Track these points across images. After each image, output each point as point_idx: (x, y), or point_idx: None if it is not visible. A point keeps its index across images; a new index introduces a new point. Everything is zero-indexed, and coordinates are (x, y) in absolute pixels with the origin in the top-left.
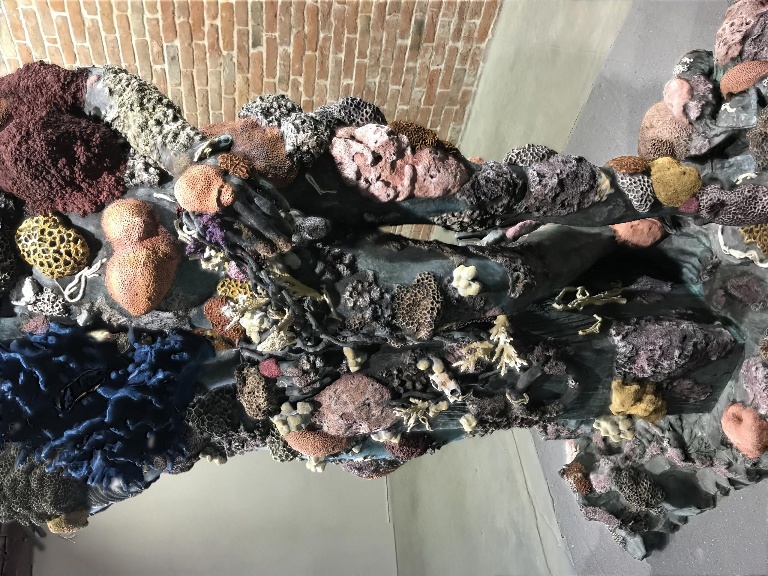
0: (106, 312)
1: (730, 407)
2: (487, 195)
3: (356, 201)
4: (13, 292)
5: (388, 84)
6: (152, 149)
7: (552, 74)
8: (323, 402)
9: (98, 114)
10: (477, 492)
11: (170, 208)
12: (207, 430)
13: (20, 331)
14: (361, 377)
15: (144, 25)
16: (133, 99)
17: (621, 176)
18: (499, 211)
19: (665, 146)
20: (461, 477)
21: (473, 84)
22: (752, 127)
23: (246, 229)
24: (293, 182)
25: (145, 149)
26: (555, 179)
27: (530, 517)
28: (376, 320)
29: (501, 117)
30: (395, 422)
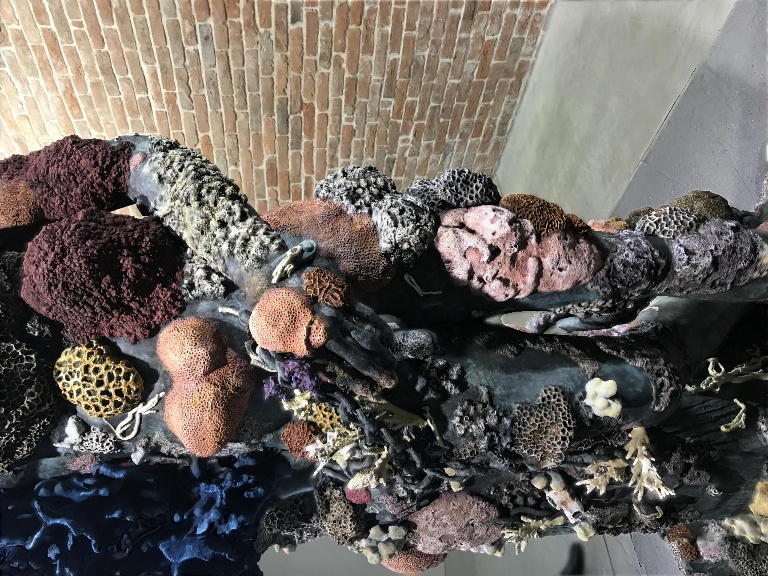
0: (165, 446)
1: None
2: (624, 282)
3: (464, 300)
4: (55, 433)
5: (438, 57)
6: (216, 258)
7: (631, 50)
8: (419, 523)
9: (145, 203)
10: None
11: (239, 325)
12: (277, 528)
13: (65, 469)
14: (465, 496)
15: (175, 4)
16: (189, 190)
17: None
18: (635, 296)
19: None
20: None
21: (531, 54)
22: None
23: (341, 371)
24: (389, 284)
25: (207, 257)
26: (709, 258)
27: None
28: (492, 449)
29: (565, 93)
30: (500, 537)
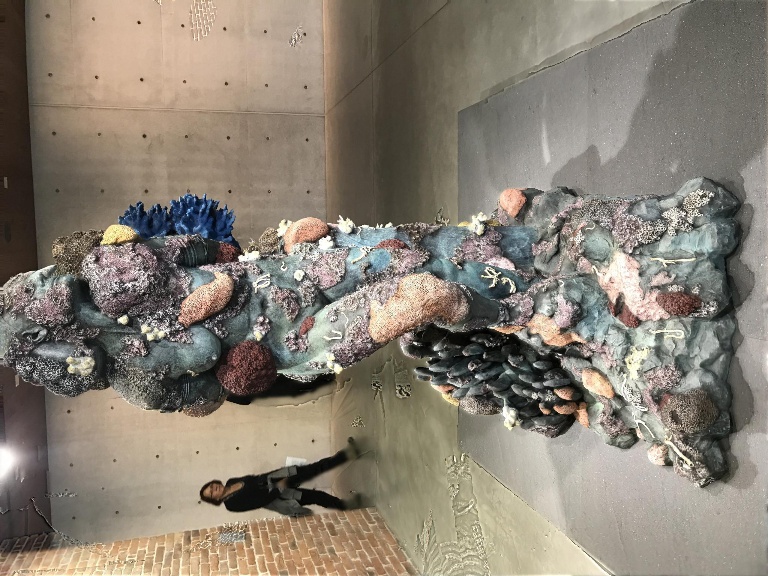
0: None
1: None
2: None
3: None
4: None
5: None
6: None
7: None
8: None
9: None
10: None
11: None
12: None
13: None
14: None
15: None
16: None
17: None
18: None
19: None
20: None
21: None
22: None
23: None
24: None
25: None
26: None
27: None
28: None
29: None
30: None
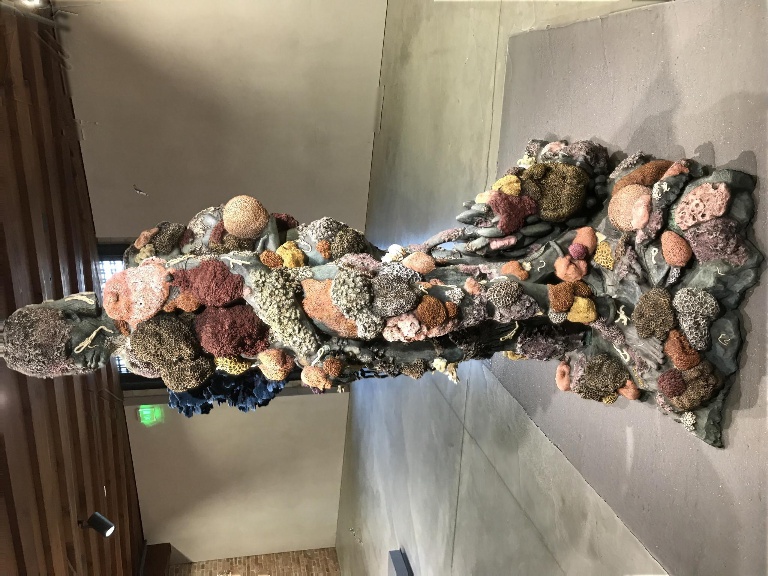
0: None
1: (564, 366)
2: (466, 327)
3: None
4: None
5: None
6: None
7: None
8: None
9: None
10: (454, 116)
11: None
12: None
13: None
14: None
15: None
16: None
17: (551, 311)
18: None
19: (618, 227)
20: (446, 91)
21: None
22: (653, 283)
23: None
24: (358, 338)
25: None
26: (509, 321)
27: (483, 180)
28: None
29: None
30: None
